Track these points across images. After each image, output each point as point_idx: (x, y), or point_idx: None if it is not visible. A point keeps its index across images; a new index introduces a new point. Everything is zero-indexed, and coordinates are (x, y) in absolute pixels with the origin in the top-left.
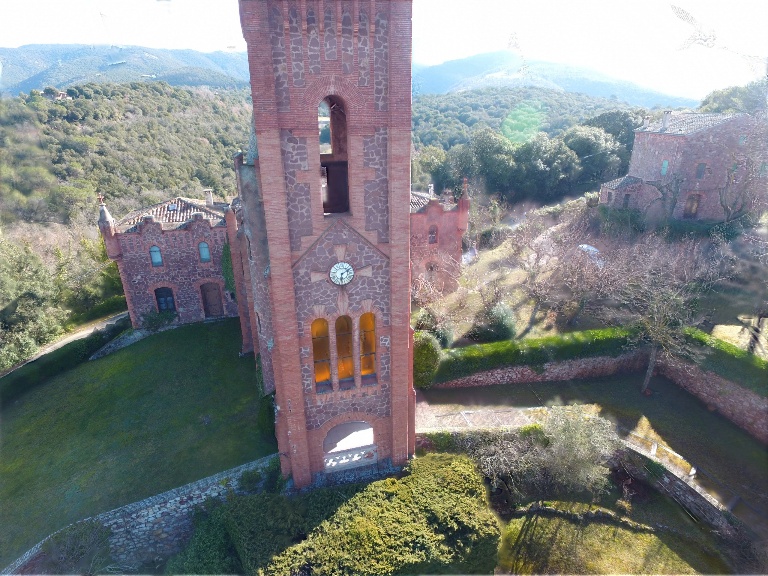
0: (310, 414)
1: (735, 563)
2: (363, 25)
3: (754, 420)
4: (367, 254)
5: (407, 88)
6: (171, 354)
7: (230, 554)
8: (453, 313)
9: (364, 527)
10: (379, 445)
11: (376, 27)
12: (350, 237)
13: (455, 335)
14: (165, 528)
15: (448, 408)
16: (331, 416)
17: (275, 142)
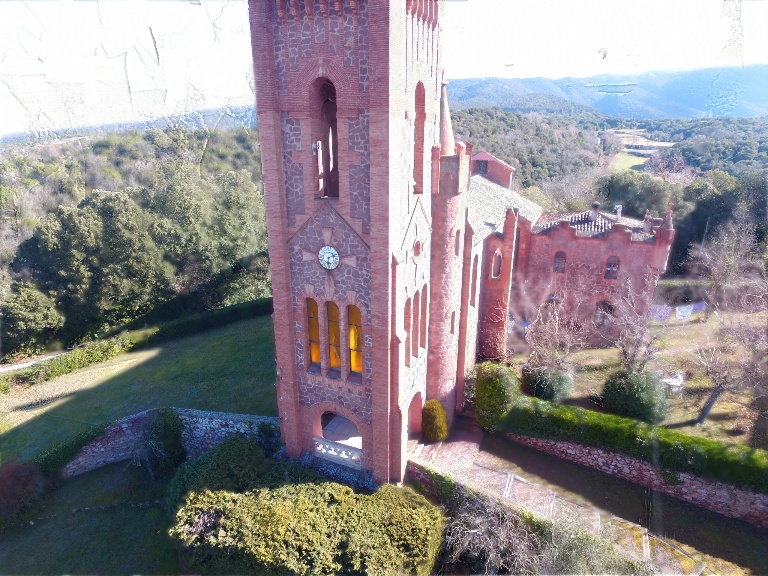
0: (303, 390)
1: None
2: (349, 3)
3: None
4: (352, 243)
5: (385, 65)
6: None
7: None
8: (603, 368)
9: (283, 512)
10: (364, 452)
11: (361, 3)
12: (337, 222)
13: (580, 392)
14: (212, 441)
15: (500, 463)
16: (320, 400)
17: (270, 122)
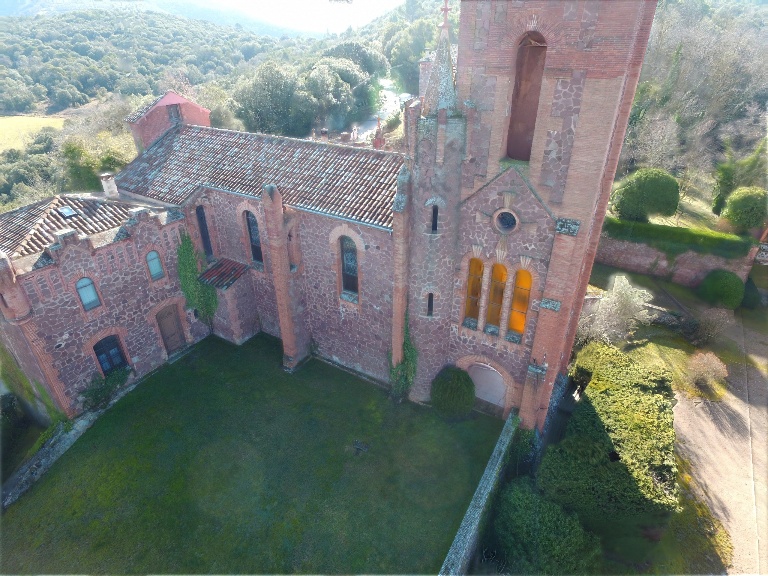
0: None
1: (686, 335)
2: None
3: (619, 257)
4: None
5: None
6: (189, 417)
7: (567, 513)
8: None
9: (633, 419)
10: None
11: None
12: None
13: None
14: (467, 554)
15: None
16: None
17: None
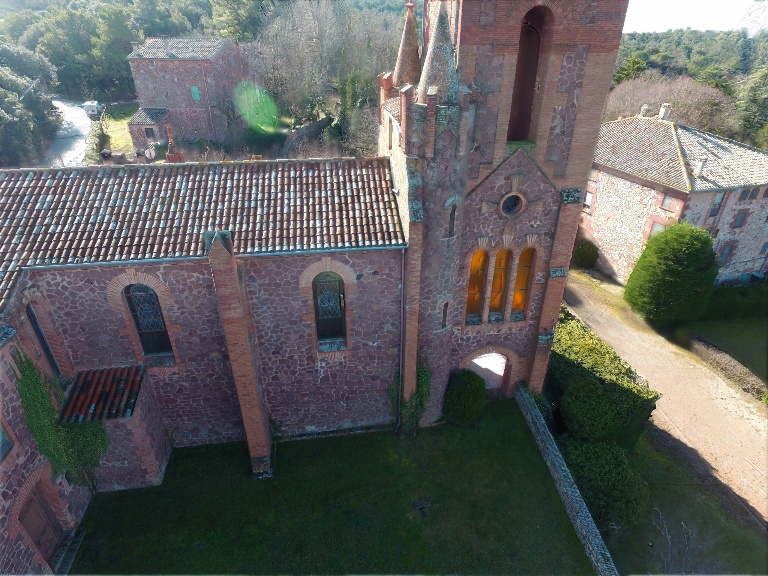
0: None
1: None
2: None
3: None
4: None
5: None
6: None
7: None
8: None
9: (583, 346)
10: None
11: None
12: None
13: None
14: None
15: None
16: None
17: None
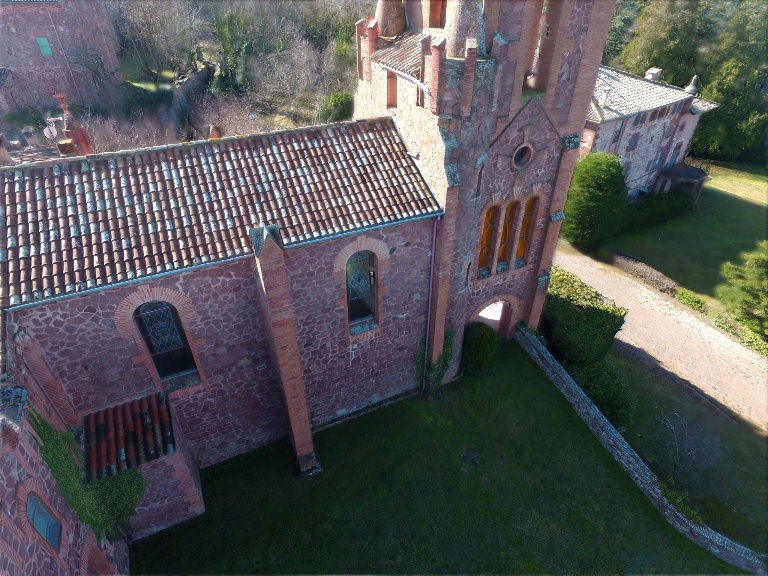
0: None
1: None
2: None
3: None
4: None
5: None
6: None
7: None
8: None
9: (554, 279)
10: None
11: None
12: None
13: None
14: None
15: None
16: None
17: None
